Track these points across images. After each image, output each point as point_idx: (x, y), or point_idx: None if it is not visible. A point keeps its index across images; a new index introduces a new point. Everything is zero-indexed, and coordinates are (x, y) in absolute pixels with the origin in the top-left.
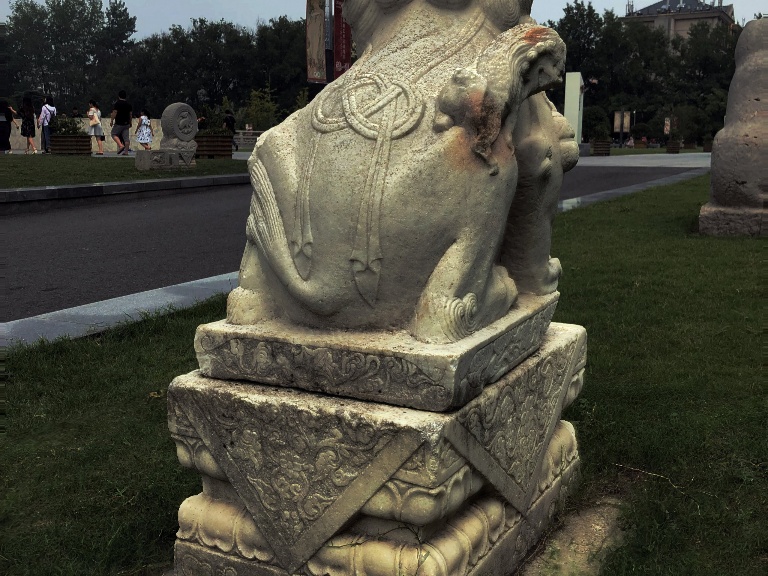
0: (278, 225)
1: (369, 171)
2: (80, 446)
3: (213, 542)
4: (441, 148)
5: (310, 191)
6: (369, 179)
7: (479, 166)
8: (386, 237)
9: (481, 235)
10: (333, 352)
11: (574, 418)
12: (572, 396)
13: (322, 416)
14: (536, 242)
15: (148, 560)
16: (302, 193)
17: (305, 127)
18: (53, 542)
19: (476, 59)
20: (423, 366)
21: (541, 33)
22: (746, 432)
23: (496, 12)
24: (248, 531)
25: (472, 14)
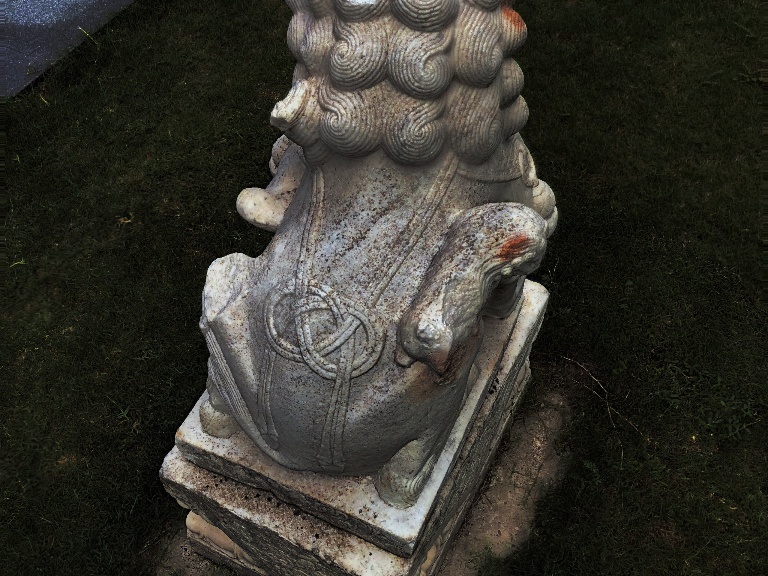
0: (241, 406)
1: (329, 409)
2: (71, 326)
3: (219, 549)
4: (402, 390)
5: (271, 404)
6: (330, 416)
7: (441, 388)
8: (349, 452)
9: (441, 425)
10: (306, 496)
11: (536, 276)
12: (528, 353)
13: (301, 548)
14: (503, 297)
15: (166, 520)
16: (263, 401)
17: (257, 324)
18: (82, 498)
19: (443, 290)
20: (386, 535)
21: (520, 247)
22: (692, 305)
23: (473, 155)
24: (247, 558)
25: (443, 163)
